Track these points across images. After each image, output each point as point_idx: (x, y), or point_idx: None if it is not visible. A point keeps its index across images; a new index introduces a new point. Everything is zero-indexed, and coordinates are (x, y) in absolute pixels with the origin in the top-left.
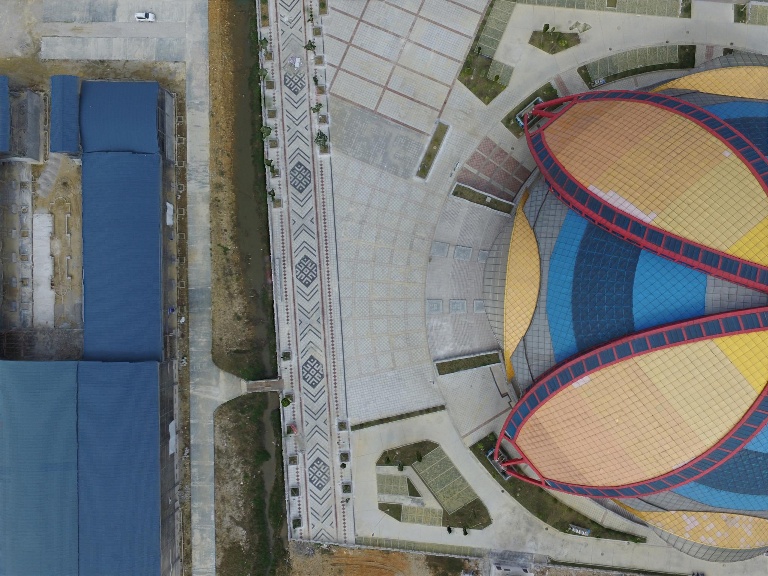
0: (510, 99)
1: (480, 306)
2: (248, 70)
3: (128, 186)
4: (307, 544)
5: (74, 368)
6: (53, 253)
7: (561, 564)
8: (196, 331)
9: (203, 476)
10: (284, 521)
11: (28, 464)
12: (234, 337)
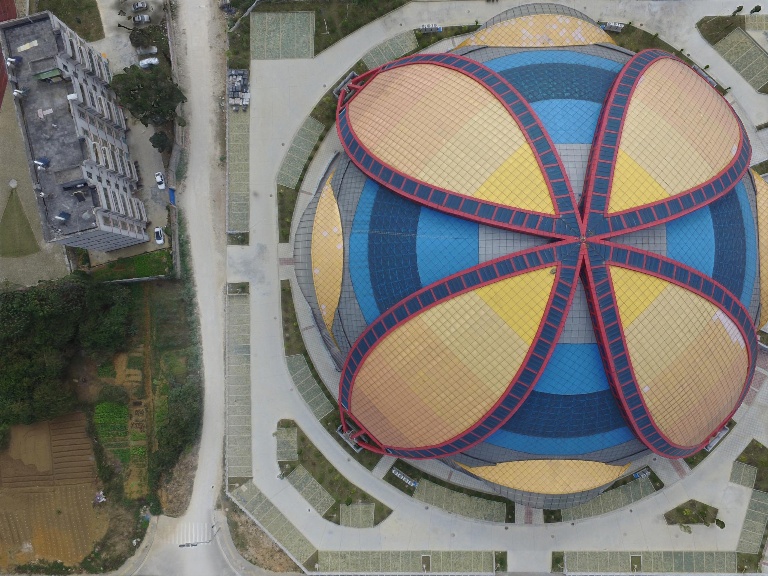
0: (730, 448)
1: None
2: None
3: None
4: None
5: None
6: None
7: None
8: None
9: None
10: None
11: None
12: None
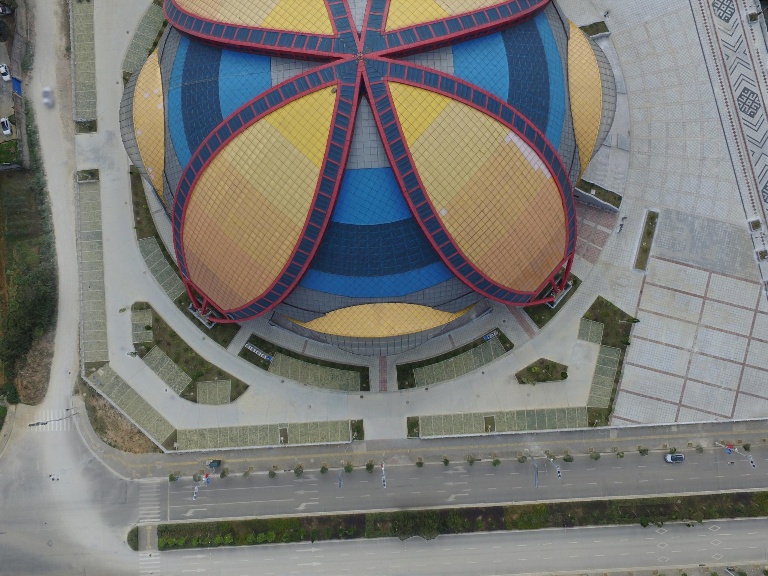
0: (576, 306)
1: None
2: None
3: None
4: None
5: None
6: None
7: None
8: None
9: None
10: None
11: None
12: None
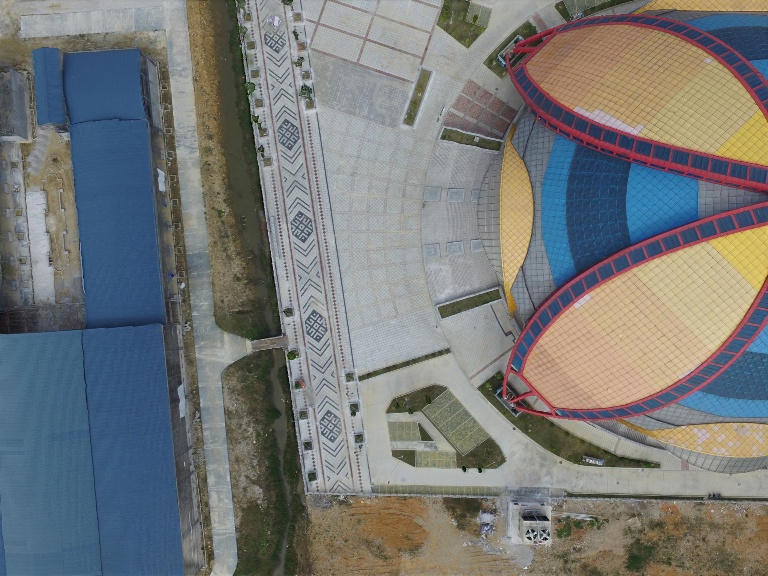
0: (490, 40)
1: (477, 245)
2: (228, 33)
3: (118, 153)
4: (324, 497)
5: (78, 337)
6: (49, 230)
7: (578, 496)
8: (197, 295)
9: (215, 438)
10: (299, 477)
11: (40, 435)
12: (235, 298)
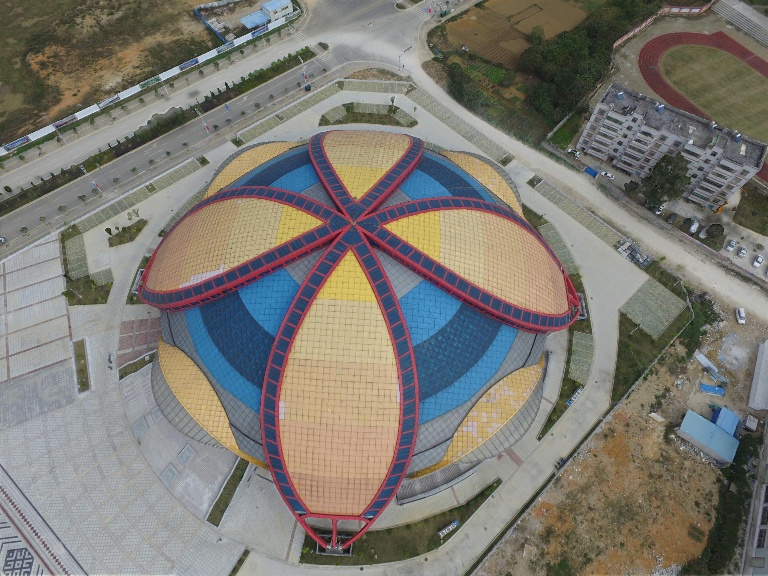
0: (122, 287)
1: None
2: None
3: None
4: None
5: None
6: None
7: None
8: None
9: None
10: None
11: None
12: None
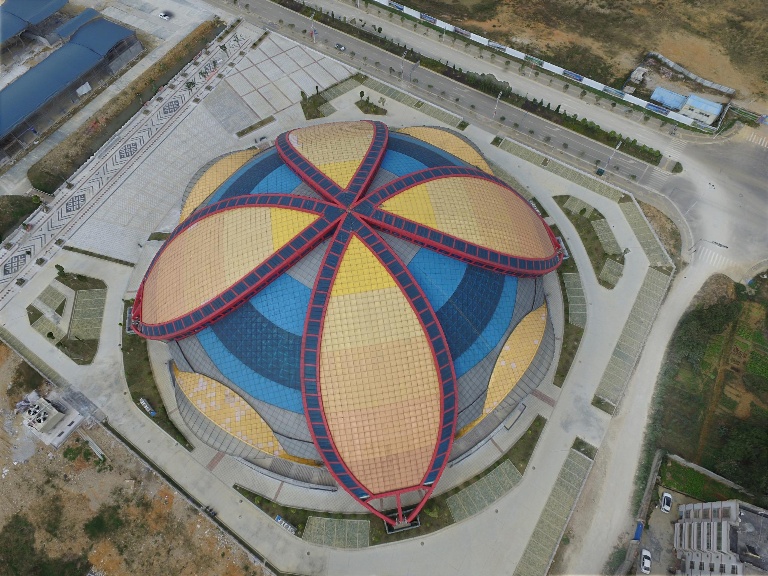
0: None
1: None
2: None
3: (72, 60)
4: None
5: None
6: None
7: (111, 429)
8: (37, 151)
9: None
10: None
11: None
12: (54, 164)
